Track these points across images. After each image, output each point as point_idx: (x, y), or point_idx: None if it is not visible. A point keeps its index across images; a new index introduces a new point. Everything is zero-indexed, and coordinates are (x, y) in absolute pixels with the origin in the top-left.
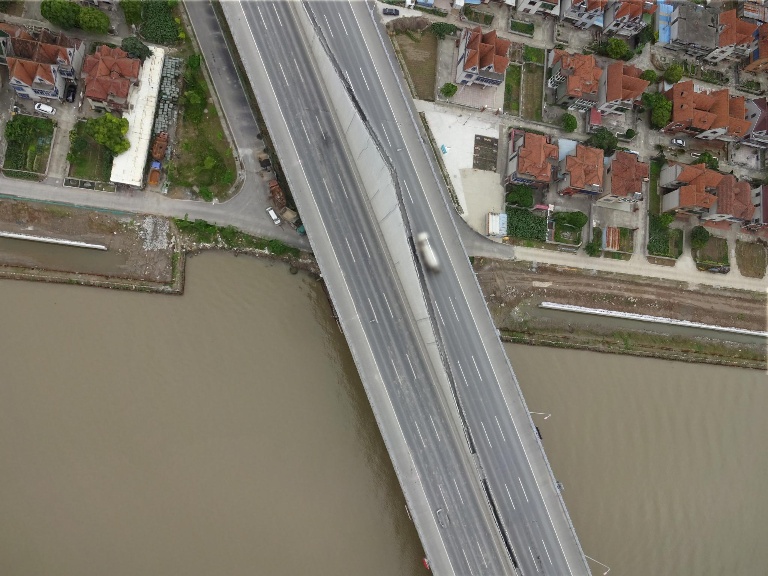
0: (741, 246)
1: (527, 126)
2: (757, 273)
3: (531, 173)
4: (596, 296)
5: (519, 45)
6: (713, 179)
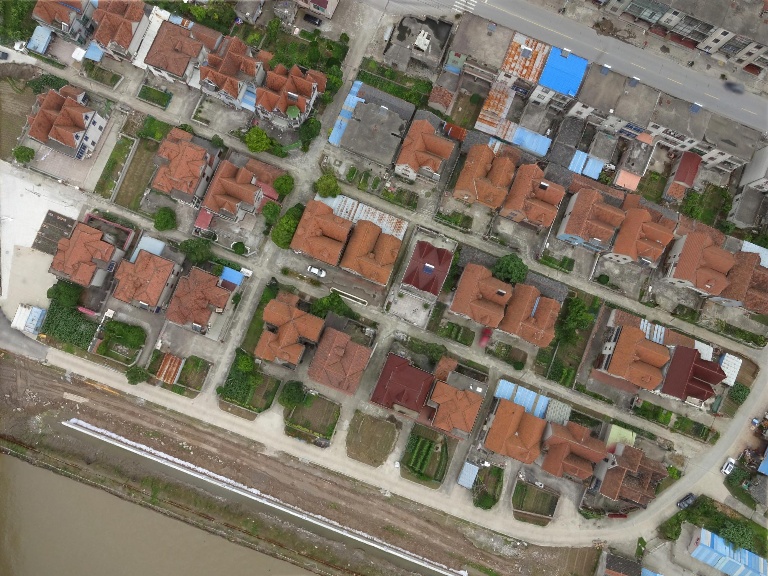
0: (361, 419)
1: (118, 212)
2: (371, 459)
3: (65, 271)
4: (141, 429)
5: (138, 116)
6: (308, 331)
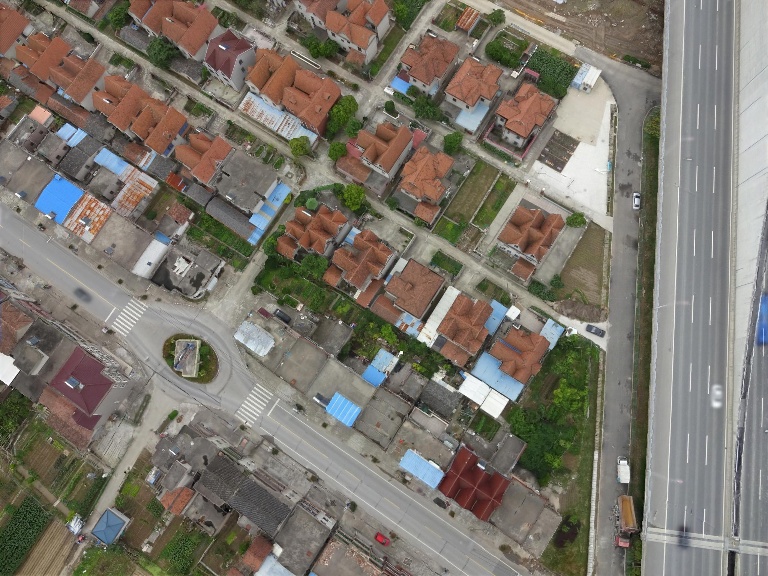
0: None
1: (497, 161)
2: None
3: None
4: None
5: None
6: None
